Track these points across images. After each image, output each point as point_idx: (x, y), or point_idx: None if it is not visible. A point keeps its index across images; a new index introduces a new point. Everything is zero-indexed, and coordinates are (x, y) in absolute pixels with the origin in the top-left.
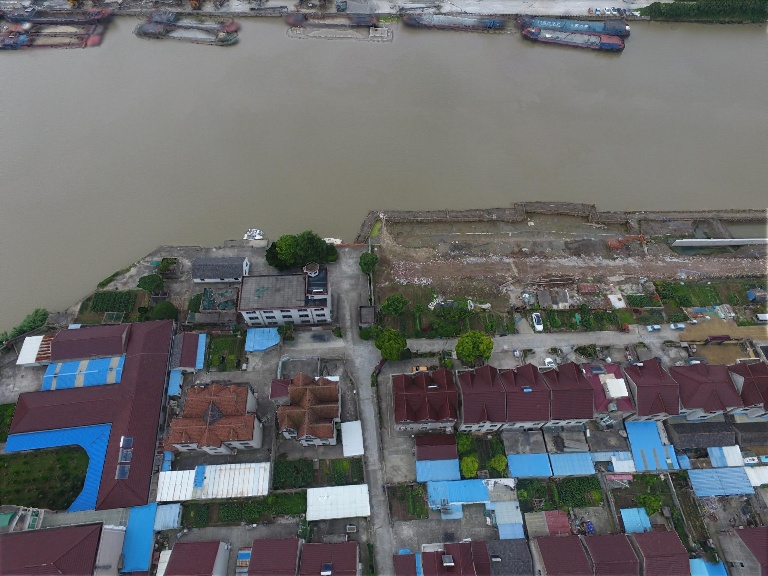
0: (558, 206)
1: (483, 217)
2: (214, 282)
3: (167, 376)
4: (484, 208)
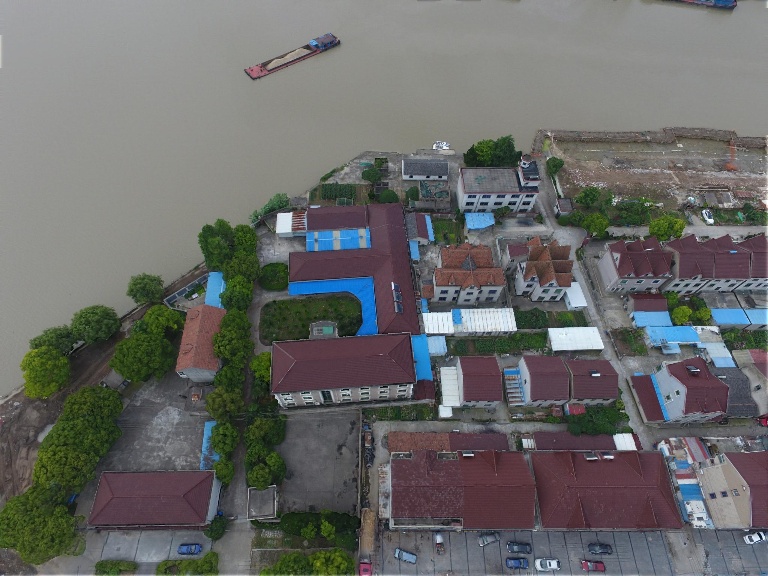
0: (702, 131)
1: (638, 138)
2: (419, 180)
3: (408, 245)
4: (637, 131)
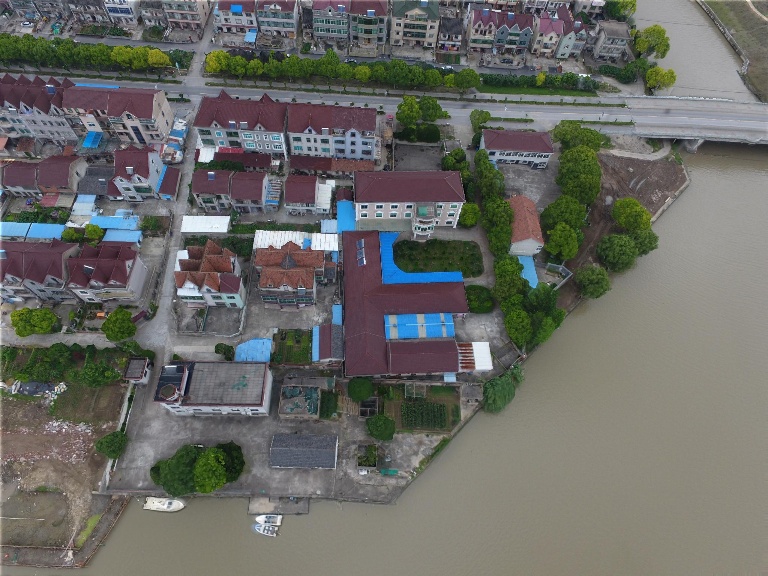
0: None
1: None
2: None
3: None
4: None
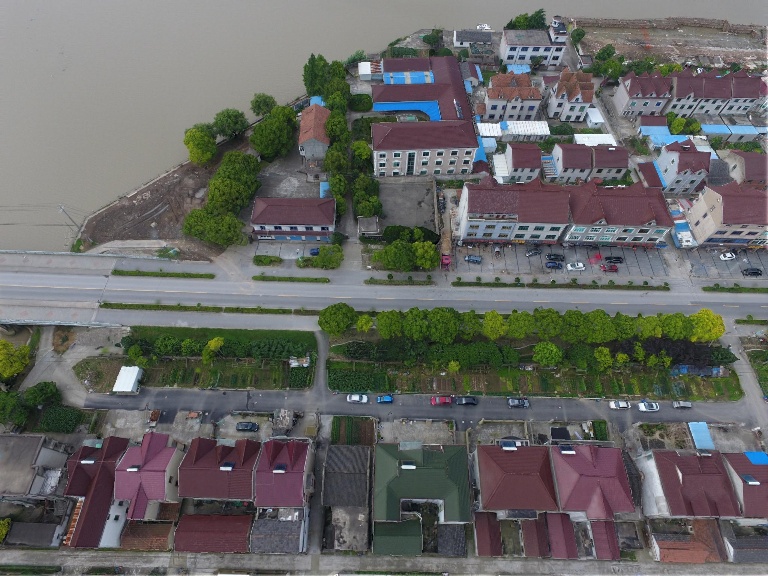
0: (700, 21)
1: (646, 24)
2: (468, 47)
3: (463, 83)
4: None
